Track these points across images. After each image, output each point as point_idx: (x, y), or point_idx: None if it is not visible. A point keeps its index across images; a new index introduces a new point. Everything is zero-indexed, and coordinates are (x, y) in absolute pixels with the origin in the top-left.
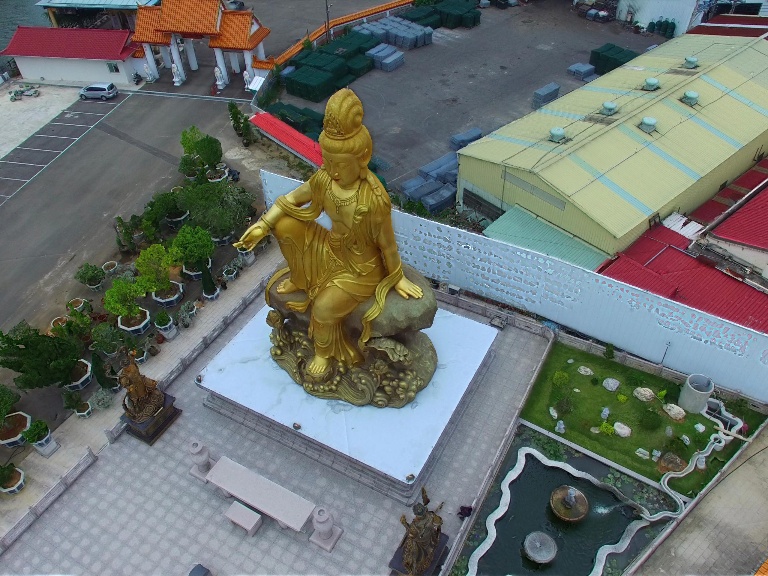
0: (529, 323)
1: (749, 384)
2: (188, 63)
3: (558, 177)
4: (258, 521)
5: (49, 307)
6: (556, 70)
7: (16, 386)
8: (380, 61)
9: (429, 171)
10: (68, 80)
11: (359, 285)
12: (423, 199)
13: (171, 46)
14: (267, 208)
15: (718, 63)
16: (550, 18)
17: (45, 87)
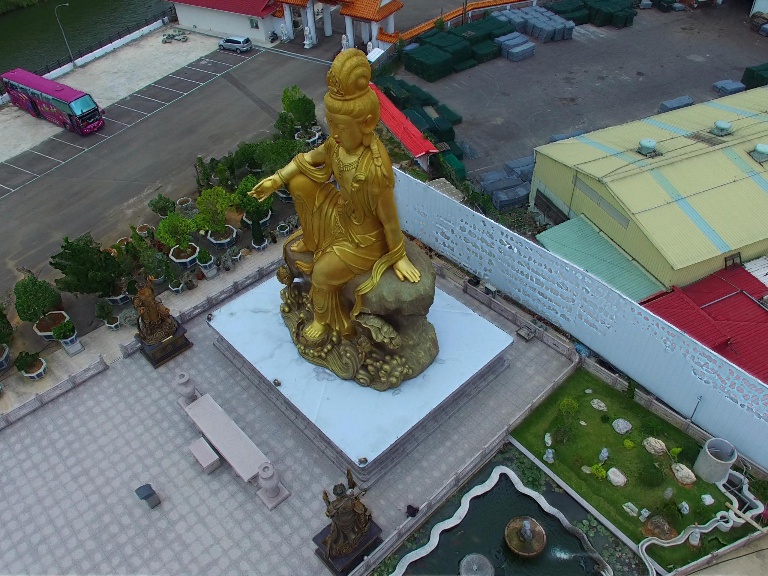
0: (557, 341)
1: None
2: (323, 28)
3: (629, 191)
4: (215, 461)
5: (123, 227)
6: (700, 84)
7: (56, 286)
8: (507, 49)
9: (515, 167)
10: (215, 31)
11: (356, 256)
12: (495, 193)
13: (307, 9)
14: None
15: None
16: (716, 28)
17: (194, 34)
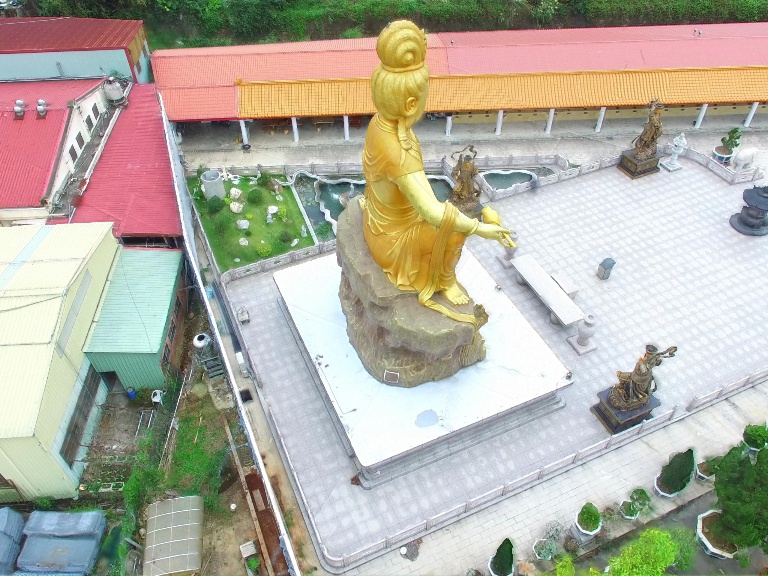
0: None
1: None
2: None
3: (55, 277)
4: None
5: None
6: None
7: None
8: None
9: None
10: None
11: None
12: (93, 528)
13: None
14: None
15: None
16: None
17: None
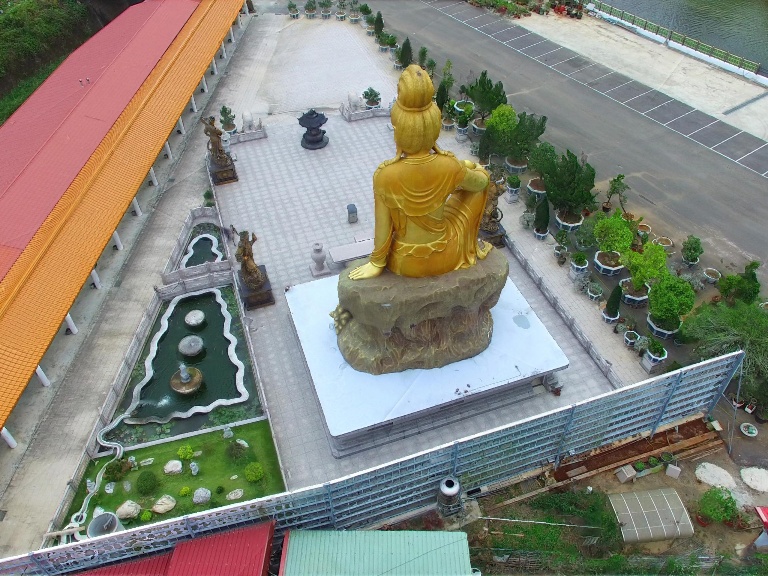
0: None
1: None
2: None
3: None
4: None
5: (679, 234)
6: None
7: None
8: None
9: None
10: None
11: None
12: None
13: None
14: None
15: None
16: None
17: None
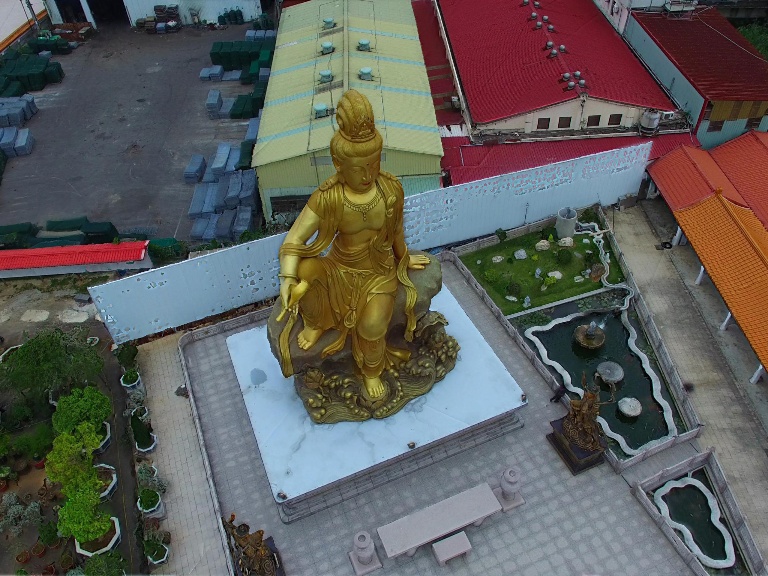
0: None
1: (579, 199)
2: None
3: None
4: (466, 537)
5: None
6: (190, 83)
7: None
8: (12, 147)
9: (201, 210)
10: None
11: (392, 281)
12: (235, 231)
13: None
14: (108, 329)
15: (346, 16)
16: (125, 45)
17: None
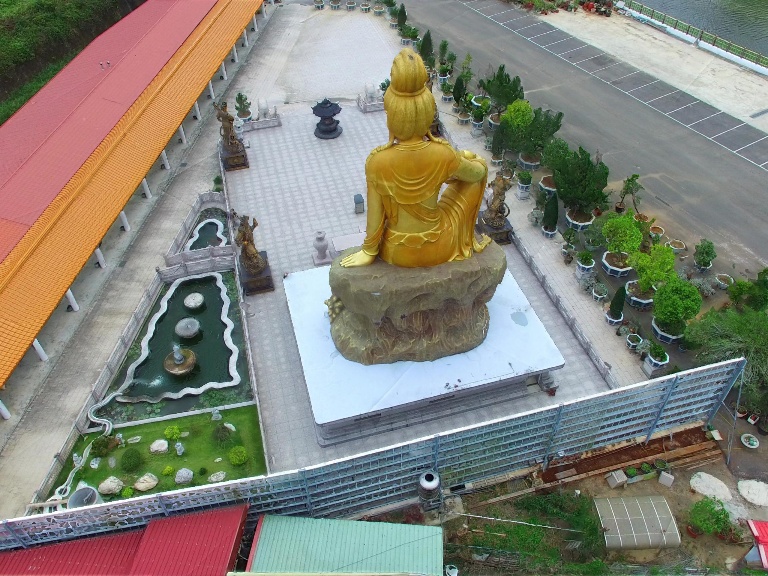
0: None
1: None
2: None
3: None
4: None
5: (694, 238)
6: None
7: None
8: None
9: None
10: None
11: None
12: None
13: None
14: None
15: None
16: None
17: None
